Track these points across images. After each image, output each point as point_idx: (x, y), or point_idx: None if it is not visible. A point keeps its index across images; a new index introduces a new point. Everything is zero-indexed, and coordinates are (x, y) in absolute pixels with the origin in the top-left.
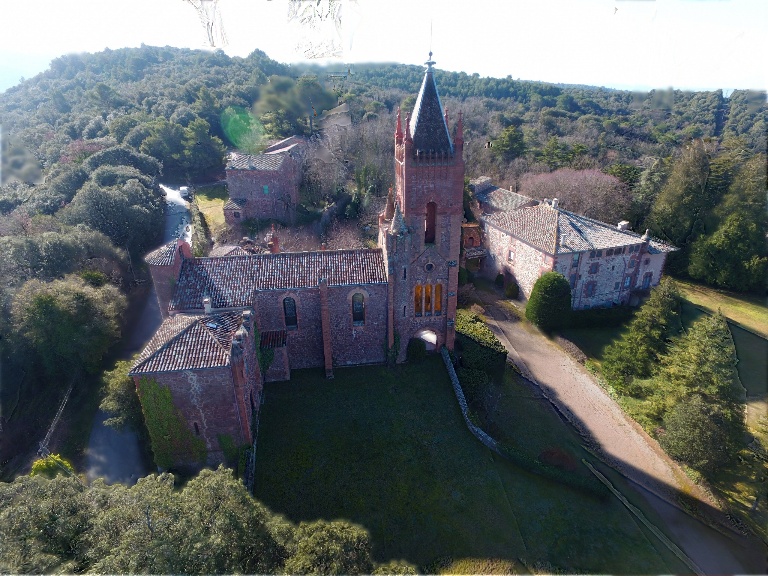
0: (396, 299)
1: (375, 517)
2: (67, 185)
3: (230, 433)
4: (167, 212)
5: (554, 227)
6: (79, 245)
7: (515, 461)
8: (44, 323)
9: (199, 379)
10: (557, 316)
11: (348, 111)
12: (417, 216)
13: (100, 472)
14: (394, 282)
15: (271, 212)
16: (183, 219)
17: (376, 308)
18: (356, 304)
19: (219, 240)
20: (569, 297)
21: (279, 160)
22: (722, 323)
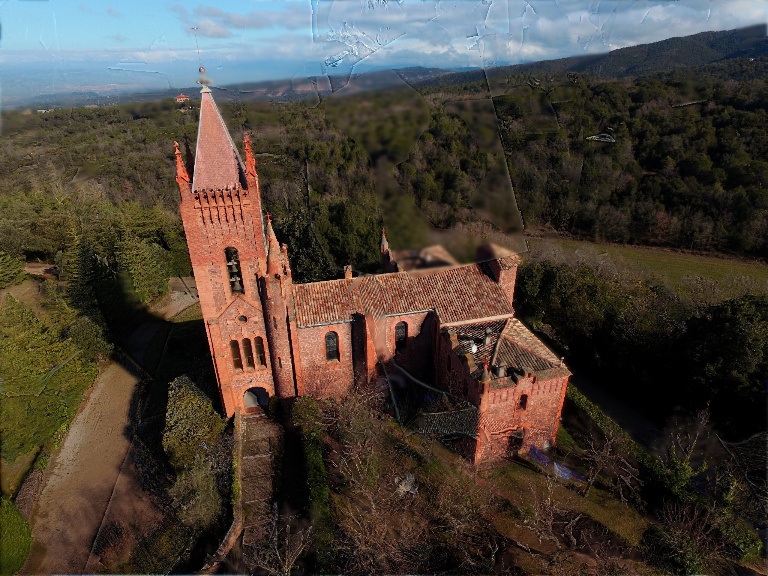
0: None
1: None
2: None
3: None
4: None
5: None
6: (727, 323)
7: None
8: None
9: None
10: None
11: None
12: None
13: None
14: None
15: None
16: None
17: None
18: None
19: None
20: None
21: None
22: (15, 300)
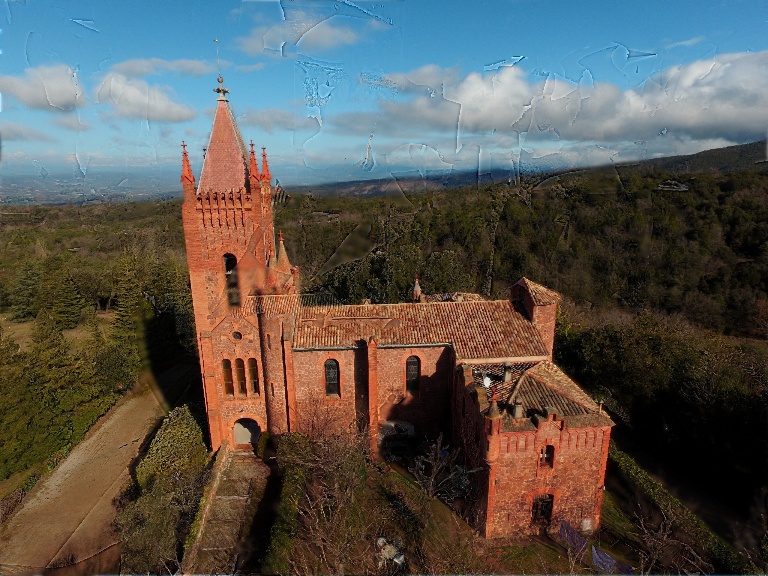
0: None
1: None
2: None
3: None
4: None
5: None
6: None
7: None
8: None
9: None
10: None
11: None
12: None
13: None
14: None
15: None
16: None
17: None
18: None
19: None
20: None
21: None
22: None
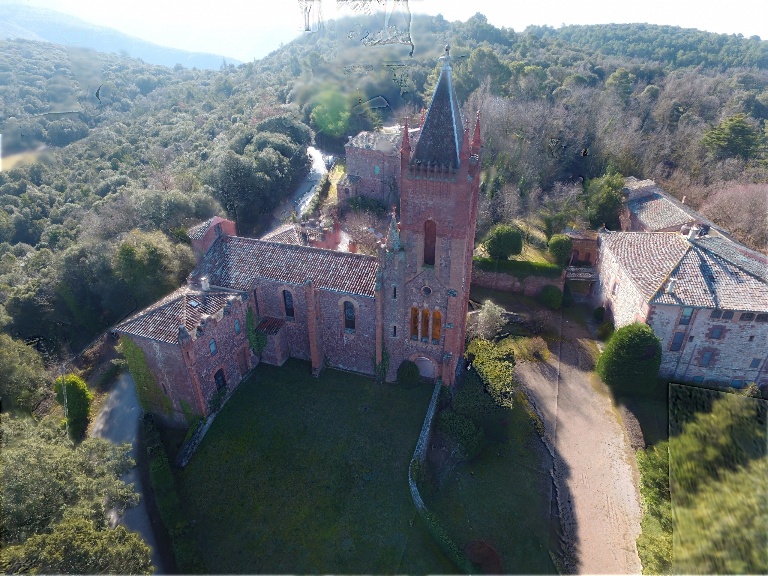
0: (385, 317)
1: (262, 528)
2: (238, 146)
3: (188, 401)
4: (305, 179)
5: (672, 266)
6: (189, 204)
7: (433, 536)
8: (123, 267)
9: (161, 349)
10: (630, 380)
11: (386, 106)
12: (414, 233)
13: (117, 397)
14: (384, 299)
15: (379, 192)
16: (312, 187)
17: (366, 320)
18: (348, 311)
19: (325, 213)
20: (654, 361)
21: (395, 141)
22: None
